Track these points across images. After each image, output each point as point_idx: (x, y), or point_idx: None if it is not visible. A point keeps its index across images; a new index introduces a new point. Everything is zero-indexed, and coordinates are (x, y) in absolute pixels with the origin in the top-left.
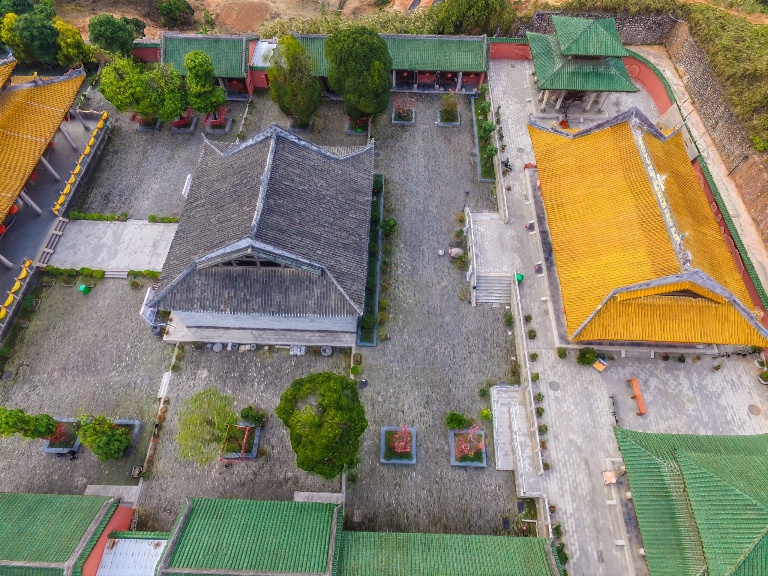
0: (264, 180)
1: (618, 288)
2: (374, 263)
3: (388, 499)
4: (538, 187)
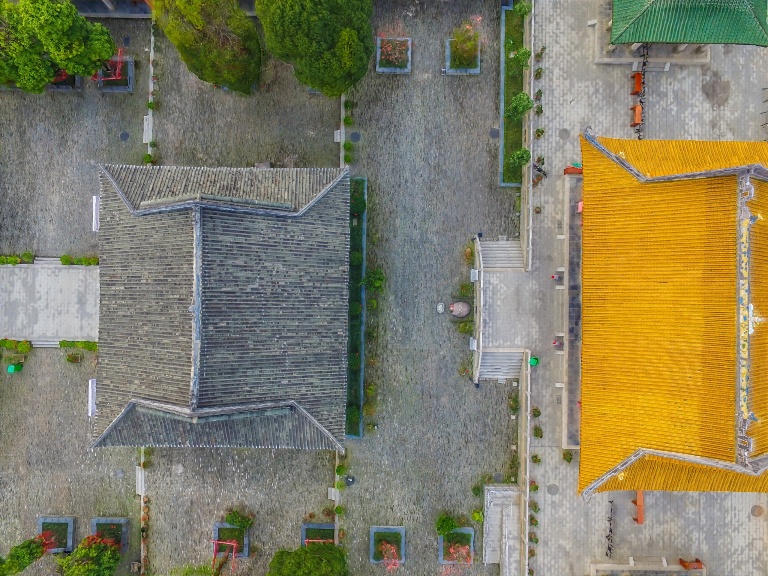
0: (194, 309)
1: (649, 451)
2: (357, 329)
3: None
4: (579, 212)
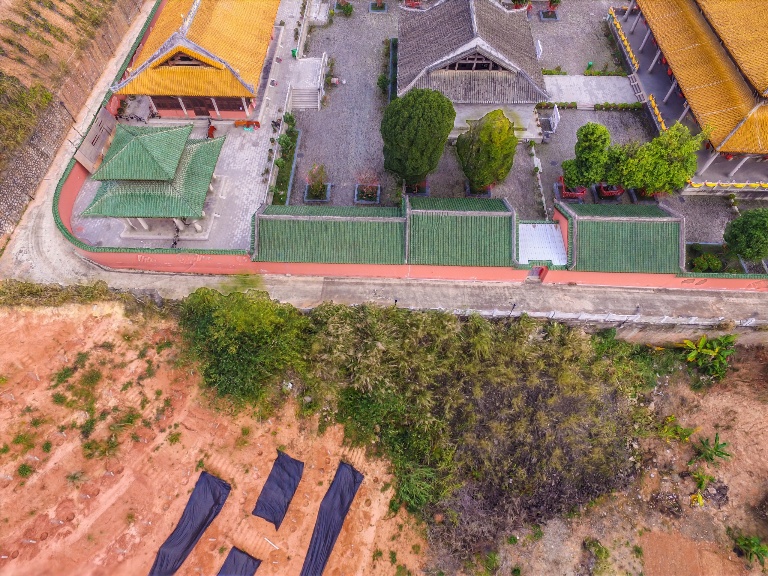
0: None
1: None
2: (394, 73)
3: None
4: None
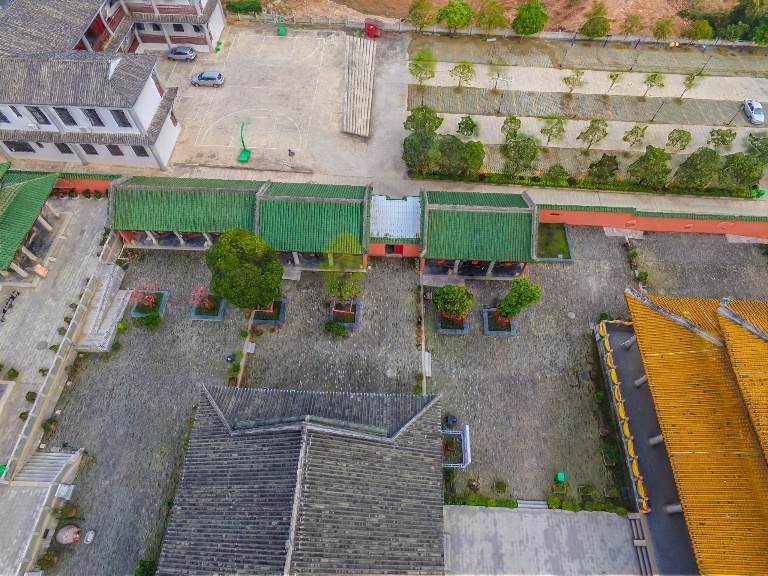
0: None
1: None
2: None
3: None
4: None
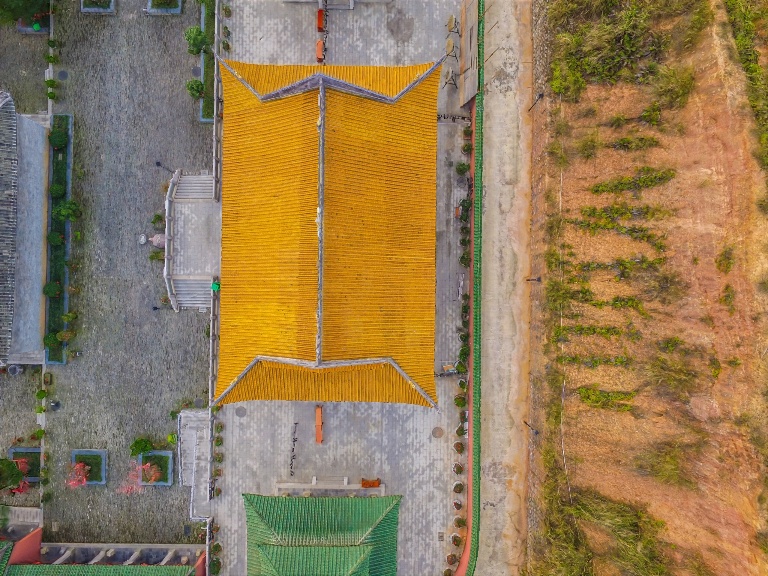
0: None
1: (259, 357)
2: (60, 259)
3: (82, 513)
4: None
